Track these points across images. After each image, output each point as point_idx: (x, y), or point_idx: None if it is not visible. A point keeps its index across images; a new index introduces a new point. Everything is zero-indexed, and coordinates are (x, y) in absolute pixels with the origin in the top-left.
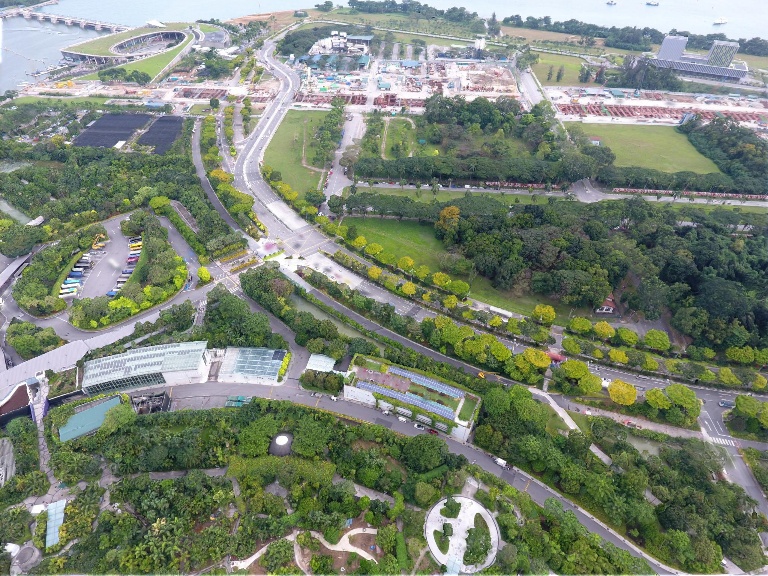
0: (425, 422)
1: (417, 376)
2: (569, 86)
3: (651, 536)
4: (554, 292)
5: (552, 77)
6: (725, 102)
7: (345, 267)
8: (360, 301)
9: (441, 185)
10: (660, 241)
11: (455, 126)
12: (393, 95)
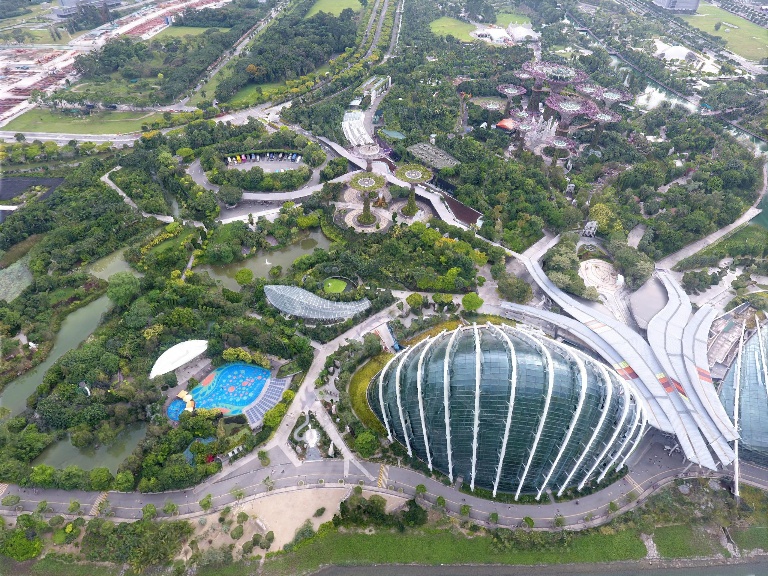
0: (384, 90)
1: (367, 83)
2: (78, 36)
3: (422, 62)
4: (319, 60)
5: (55, 37)
6: (148, 13)
7: (281, 103)
8: (319, 91)
9: (202, 80)
10: (302, 32)
11: (133, 62)
12: (15, 89)
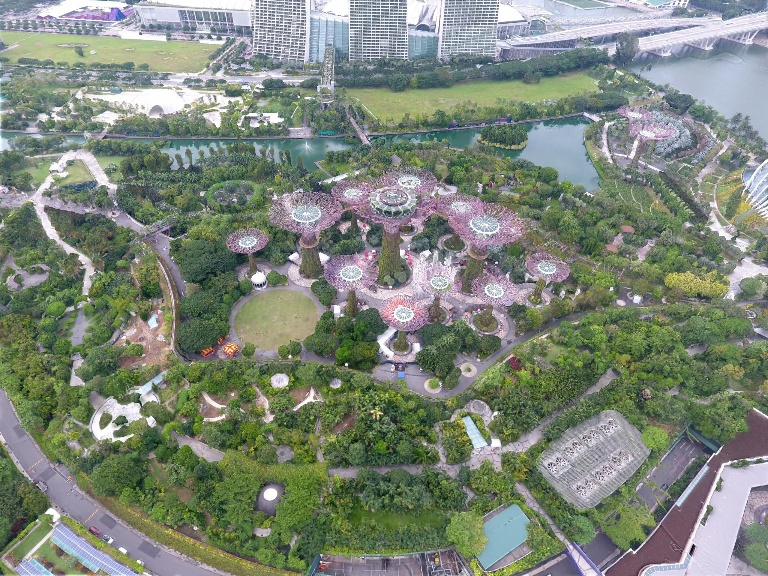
0: None
1: None
2: None
3: None
4: None
5: None
6: None
7: None
8: None
9: None
10: None
11: None
12: None
